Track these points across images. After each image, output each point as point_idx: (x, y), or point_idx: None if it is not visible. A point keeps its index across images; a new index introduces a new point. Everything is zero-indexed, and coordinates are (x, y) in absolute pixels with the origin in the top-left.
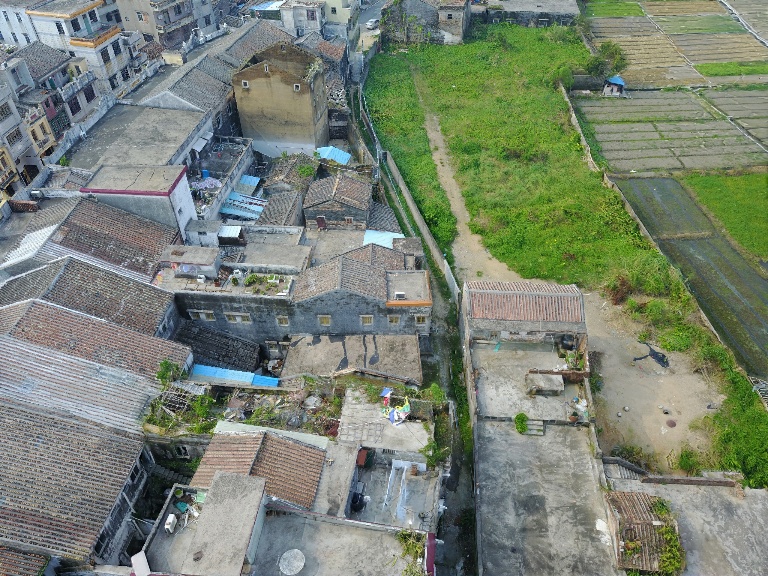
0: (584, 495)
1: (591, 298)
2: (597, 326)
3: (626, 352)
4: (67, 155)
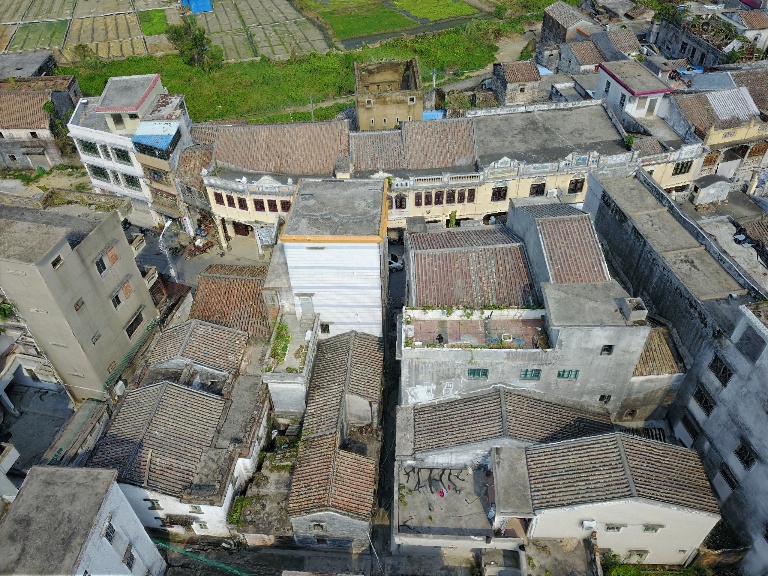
0: (640, 22)
1: (500, 45)
2: None
3: (533, 37)
4: None
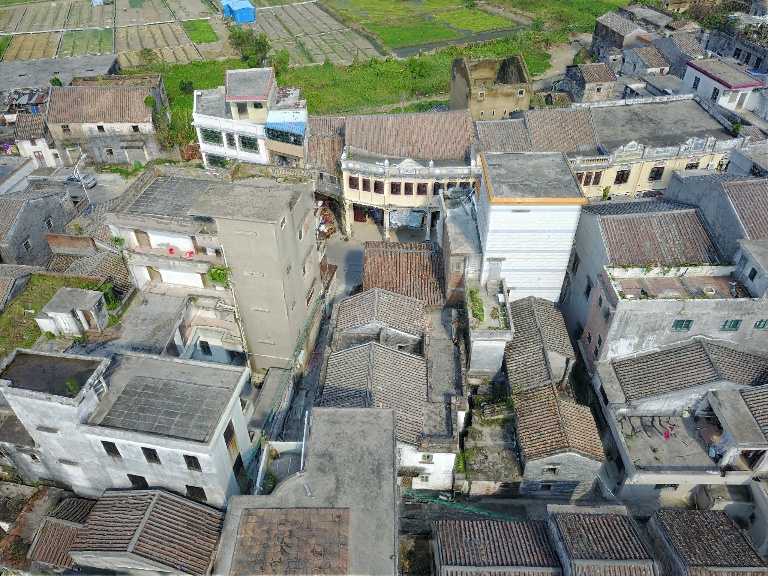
0: None
1: (550, 53)
2: (569, 51)
3: None
4: None
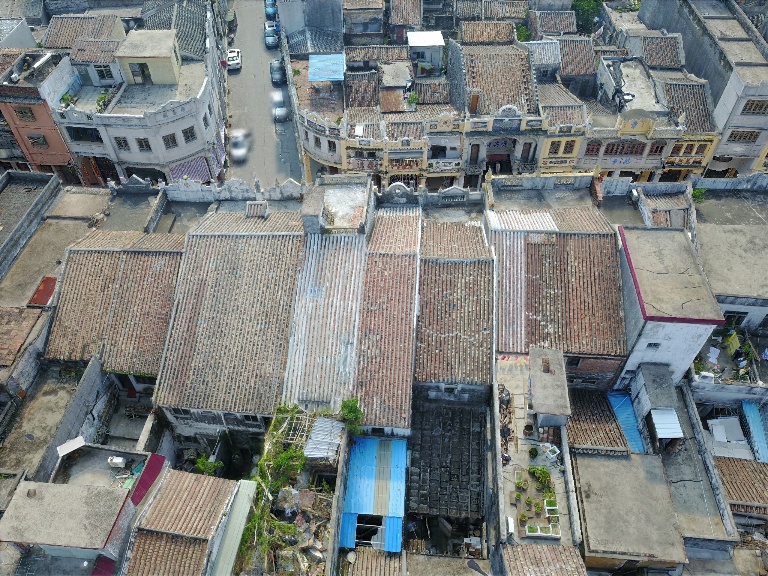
0: None
1: None
2: None
3: None
4: (727, 192)
